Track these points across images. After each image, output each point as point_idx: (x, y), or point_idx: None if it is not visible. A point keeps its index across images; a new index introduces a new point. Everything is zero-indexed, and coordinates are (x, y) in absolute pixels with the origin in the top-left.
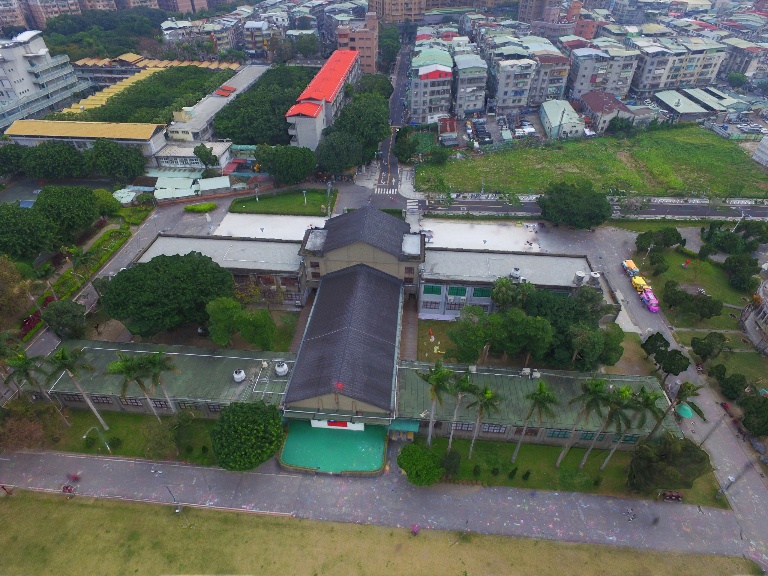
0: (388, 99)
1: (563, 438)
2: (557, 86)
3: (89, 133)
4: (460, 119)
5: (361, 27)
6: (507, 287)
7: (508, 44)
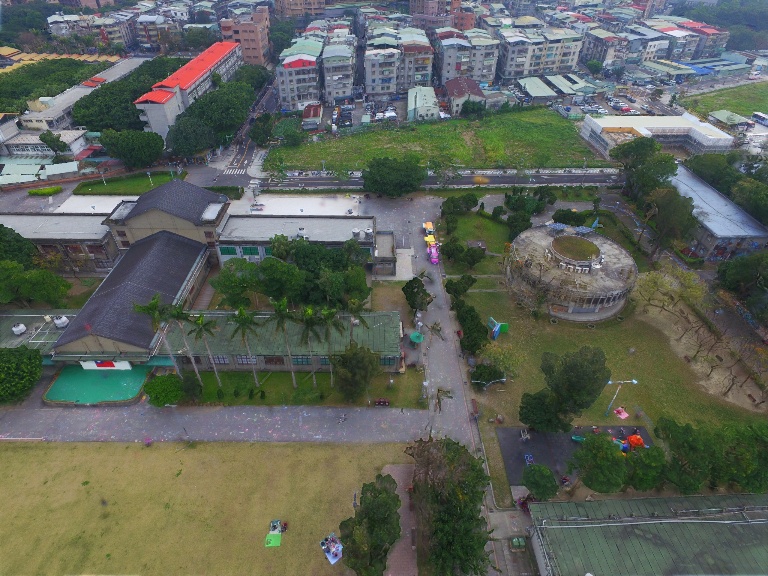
0: (269, 89)
1: (307, 365)
2: (423, 74)
3: None
4: (331, 106)
5: (249, 20)
6: (280, 242)
7: (384, 35)
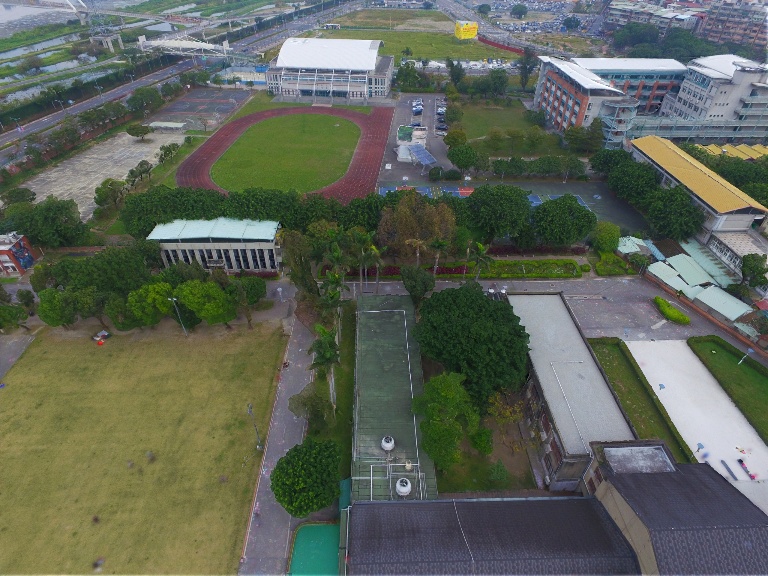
0: None
1: None
2: None
3: (682, 175)
4: None
5: None
6: None
7: None
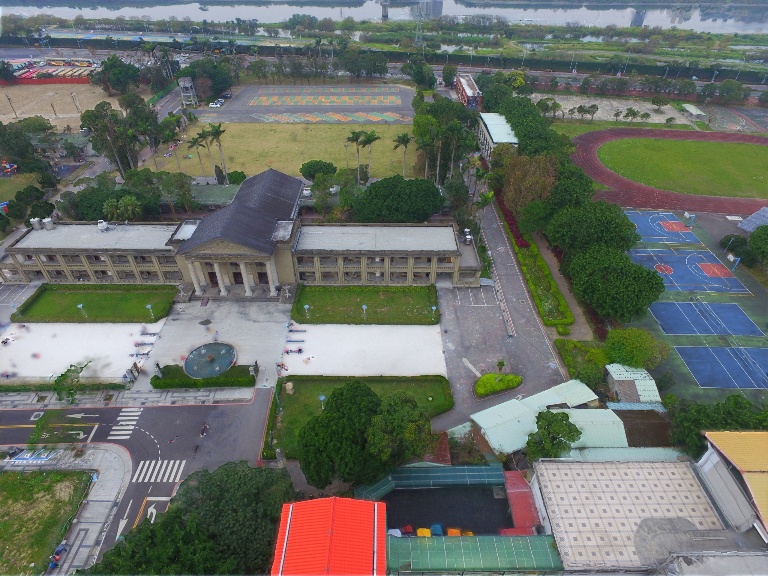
0: None
1: None
2: None
3: None
4: None
5: None
6: None
7: None
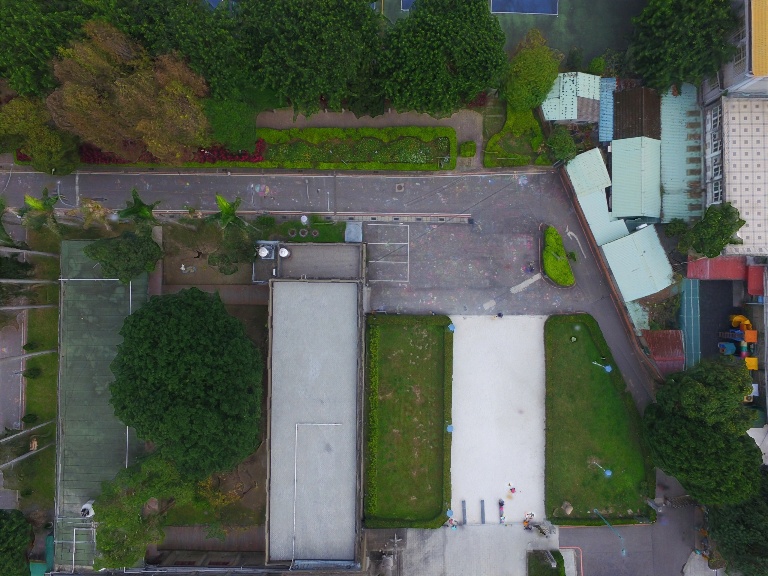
0: None
1: None
2: None
3: None
4: None
5: None
6: None
7: None
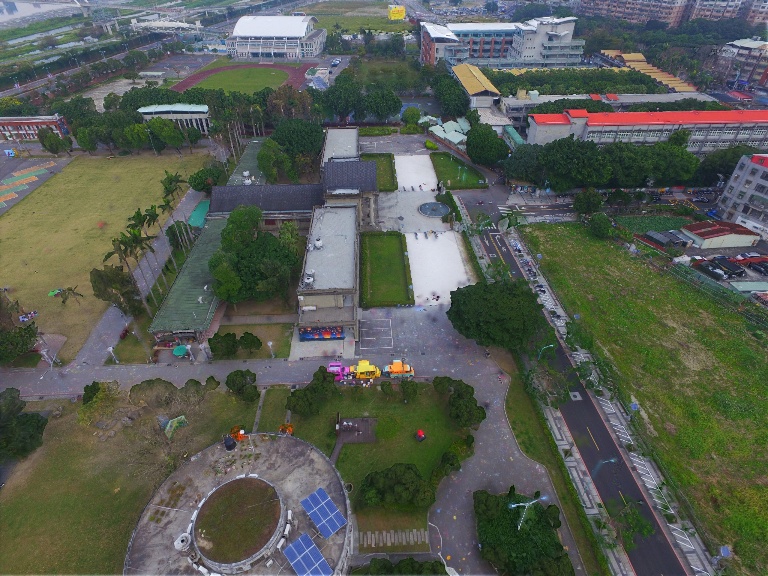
0: None
1: None
2: None
3: None
4: None
5: None
6: None
7: None
